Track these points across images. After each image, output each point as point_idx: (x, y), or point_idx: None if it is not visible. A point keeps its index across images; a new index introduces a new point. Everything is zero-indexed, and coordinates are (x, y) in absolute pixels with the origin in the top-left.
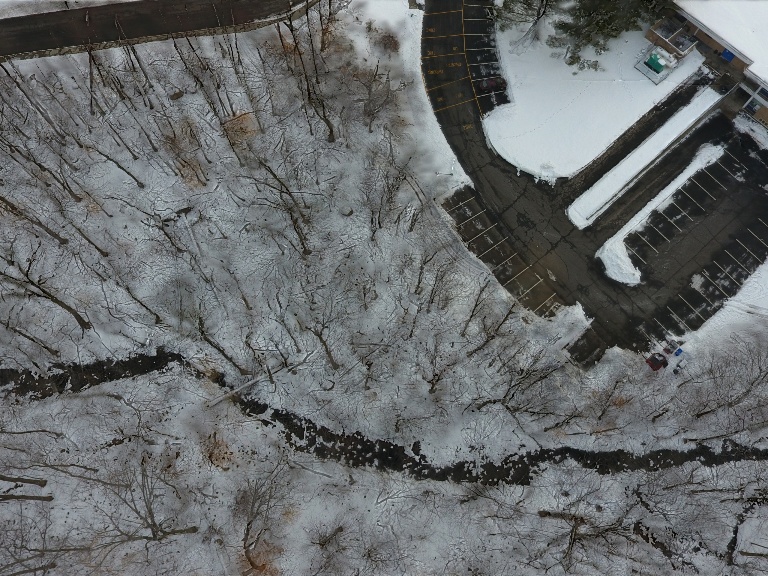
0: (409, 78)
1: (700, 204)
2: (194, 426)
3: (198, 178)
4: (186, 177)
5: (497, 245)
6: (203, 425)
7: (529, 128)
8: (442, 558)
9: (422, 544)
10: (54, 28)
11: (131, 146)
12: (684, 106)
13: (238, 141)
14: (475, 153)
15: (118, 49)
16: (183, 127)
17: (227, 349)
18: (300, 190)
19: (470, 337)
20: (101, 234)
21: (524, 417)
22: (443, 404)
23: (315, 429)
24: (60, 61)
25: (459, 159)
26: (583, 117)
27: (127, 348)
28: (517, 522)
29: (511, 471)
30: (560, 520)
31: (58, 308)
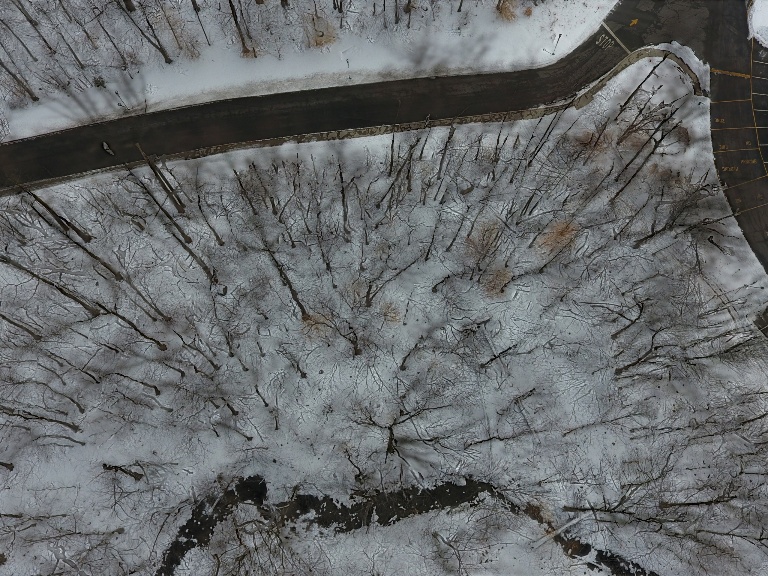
0: None
1: None
2: (519, 570)
3: None
4: (487, 284)
5: None
6: (528, 569)
7: None
8: None
9: None
10: (328, 107)
11: None
12: None
13: None
14: None
15: (401, 134)
16: (486, 230)
17: None
18: (605, 301)
19: None
20: (413, 352)
21: None
22: None
23: (644, 575)
24: (340, 146)
25: (766, 270)
26: None
27: (433, 475)
28: None
29: None
30: None
31: (363, 430)
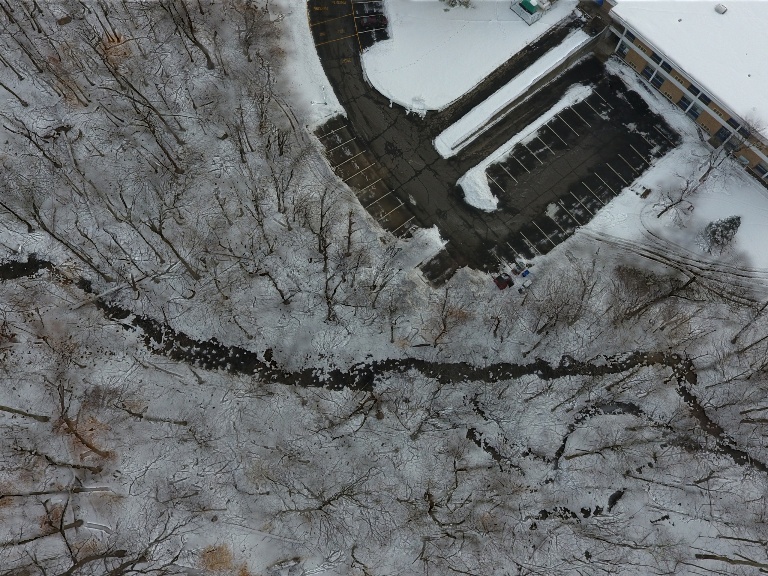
0: (294, 13)
1: (563, 139)
2: (56, 327)
3: (78, 97)
4: (67, 97)
5: (363, 170)
6: (65, 326)
7: (405, 63)
8: (278, 452)
9: (261, 439)
10: None
11: (14, 65)
12: (555, 46)
13: (121, 65)
14: (351, 85)
15: None
16: (65, 49)
17: (95, 258)
18: (178, 113)
19: (328, 254)
20: None
21: (373, 329)
22: (296, 314)
23: (173, 334)
24: None
25: (335, 90)
26: (457, 54)
27: (0, 255)
28: (354, 422)
29: (356, 378)
30: (396, 423)
31: None
